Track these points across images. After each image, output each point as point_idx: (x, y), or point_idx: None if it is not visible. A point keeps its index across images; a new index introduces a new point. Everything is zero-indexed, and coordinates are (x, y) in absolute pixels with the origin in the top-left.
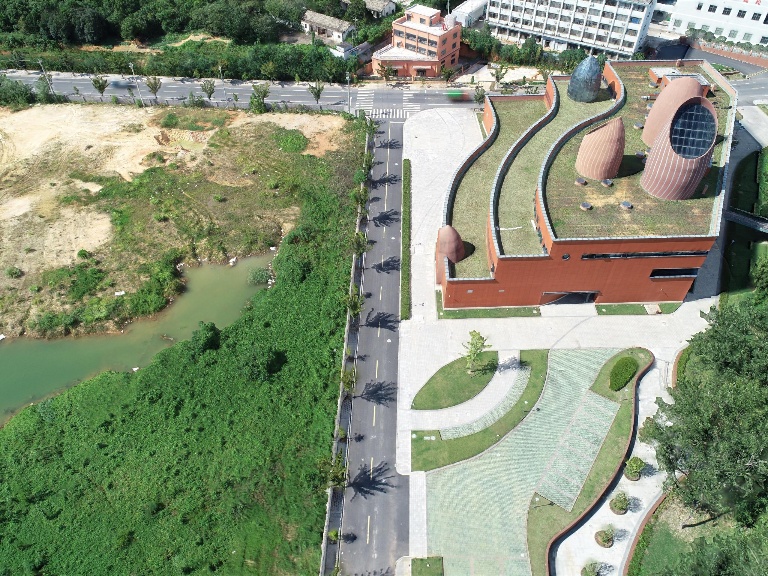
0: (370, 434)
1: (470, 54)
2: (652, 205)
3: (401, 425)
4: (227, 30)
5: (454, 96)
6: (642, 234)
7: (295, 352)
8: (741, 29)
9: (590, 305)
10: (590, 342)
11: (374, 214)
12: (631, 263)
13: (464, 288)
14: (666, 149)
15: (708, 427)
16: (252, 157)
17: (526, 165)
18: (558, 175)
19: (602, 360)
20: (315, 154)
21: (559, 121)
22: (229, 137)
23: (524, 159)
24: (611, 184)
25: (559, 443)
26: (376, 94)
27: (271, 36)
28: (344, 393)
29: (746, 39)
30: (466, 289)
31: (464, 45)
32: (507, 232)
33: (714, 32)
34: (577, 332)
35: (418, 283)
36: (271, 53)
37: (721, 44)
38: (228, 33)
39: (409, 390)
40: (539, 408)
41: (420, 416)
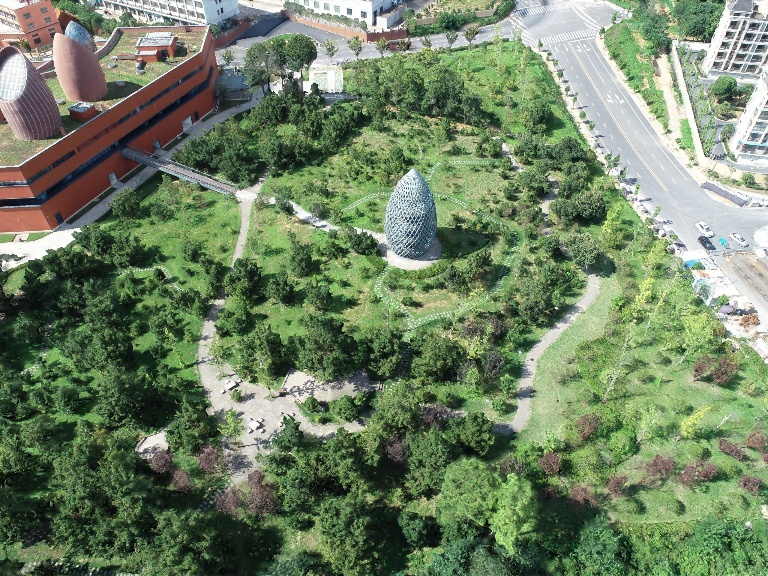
0: None
1: None
2: (5, 145)
3: None
4: None
5: None
6: None
7: None
8: (330, 2)
9: None
10: None
11: None
12: None
13: None
14: None
15: None
16: None
17: None
18: None
19: None
20: None
21: None
22: None
23: None
24: None
25: None
26: None
27: None
28: None
29: (337, 11)
30: None
31: (76, 20)
32: None
33: (314, 5)
34: None
35: None
36: None
37: (310, 16)
38: None
39: None
40: None
41: None
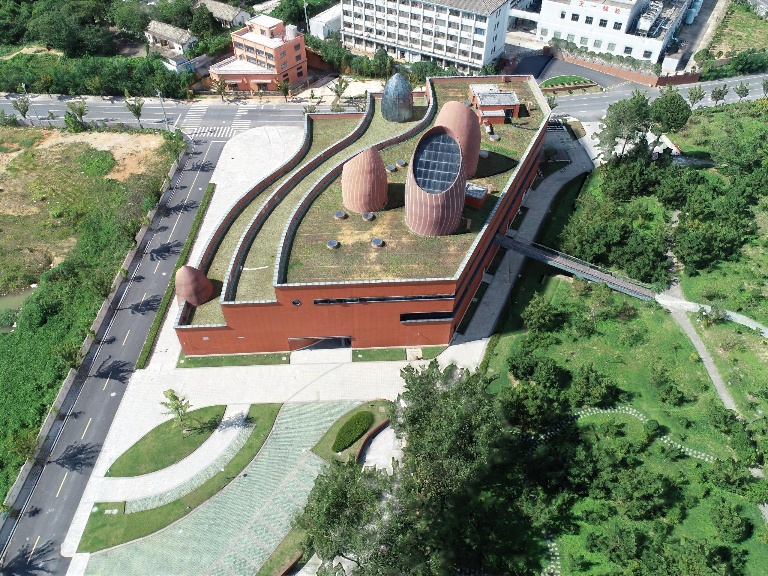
0: (48, 507)
1: (323, 66)
2: (407, 242)
3: (87, 496)
4: (55, 42)
5: (291, 112)
6: (381, 276)
7: (0, 409)
8: (605, 39)
9: (347, 350)
10: (331, 394)
11: (154, 246)
12: (373, 308)
13: (197, 335)
14: (411, 183)
15: (326, 520)
16: (48, 182)
17: (304, 194)
18: (321, 207)
19: (337, 415)
20: (117, 178)
21: (361, 143)
22: (32, 159)
23: (304, 187)
24: (373, 218)
25: (253, 516)
26: (209, 110)
27: (105, 48)
28: (31, 459)
29: (611, 49)
30: (200, 336)
31: (317, 56)
32: (249, 273)
33: (580, 42)
34: (322, 382)
35: (170, 326)
36: (99, 67)
37: (583, 55)
38: (57, 46)
39: (112, 453)
40: (247, 473)
41: (111, 485)
